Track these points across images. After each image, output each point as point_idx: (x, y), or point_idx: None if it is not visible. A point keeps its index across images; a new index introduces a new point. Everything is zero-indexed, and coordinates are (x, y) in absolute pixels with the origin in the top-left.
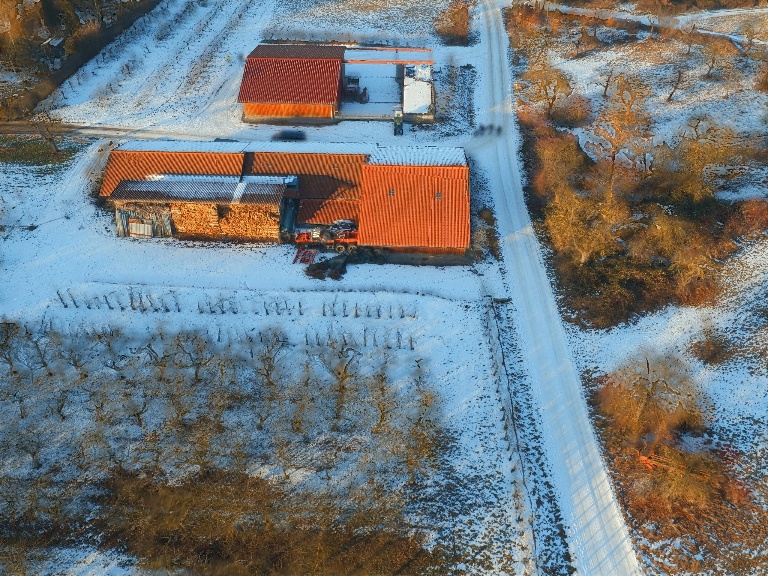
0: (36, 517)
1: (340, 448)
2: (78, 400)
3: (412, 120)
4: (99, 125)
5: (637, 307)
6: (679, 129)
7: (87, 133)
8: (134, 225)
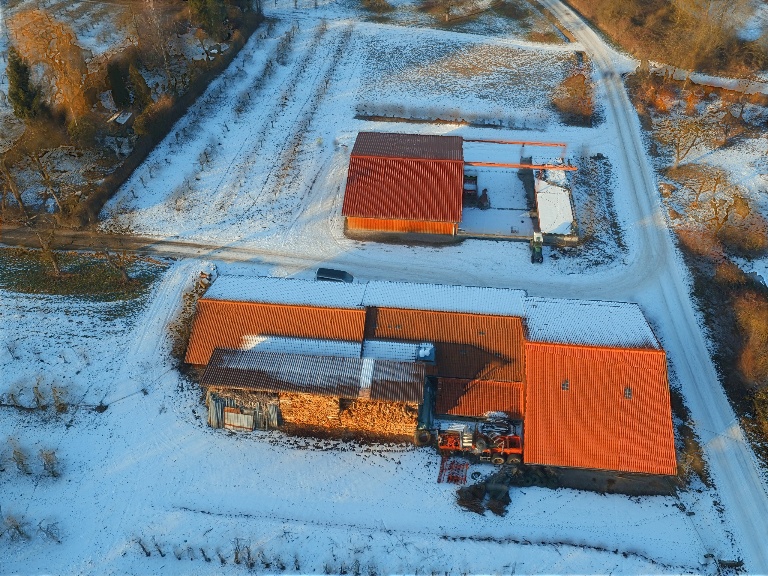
0: None
1: None
2: None
3: (551, 241)
4: (176, 239)
5: None
6: None
7: (162, 250)
8: (231, 415)
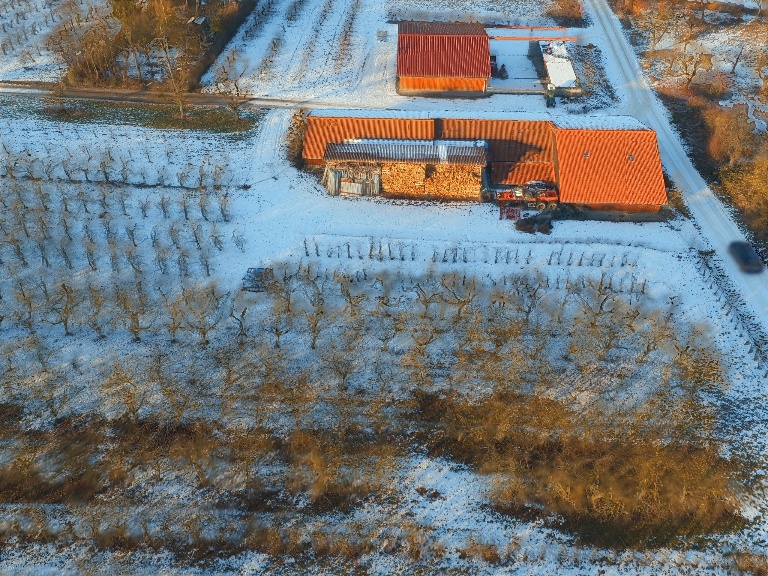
0: (361, 430)
1: (613, 375)
2: None
3: (560, 94)
4: (267, 97)
5: None
6: None
7: (258, 104)
8: (345, 184)
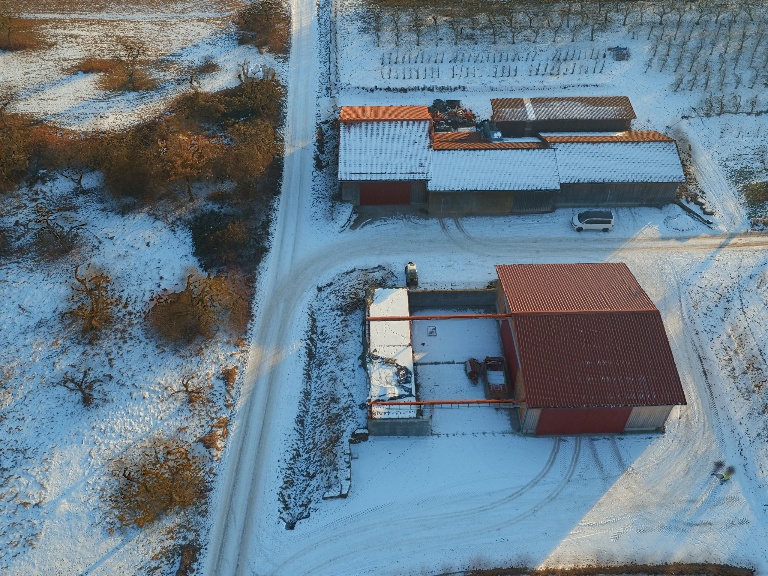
0: None
1: None
2: (548, 33)
3: None
4: None
5: None
6: (45, 300)
7: None
8: None
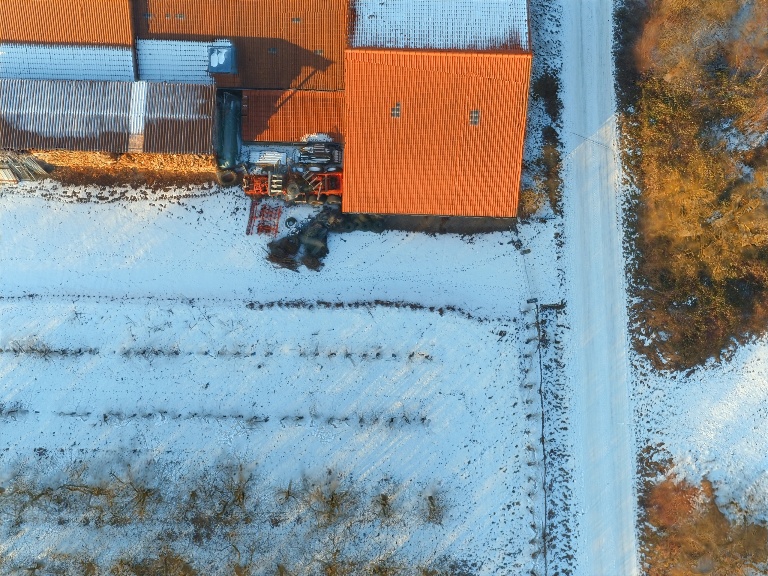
0: None
1: None
2: (5, 533)
3: None
4: None
5: (739, 329)
6: None
7: None
8: None
